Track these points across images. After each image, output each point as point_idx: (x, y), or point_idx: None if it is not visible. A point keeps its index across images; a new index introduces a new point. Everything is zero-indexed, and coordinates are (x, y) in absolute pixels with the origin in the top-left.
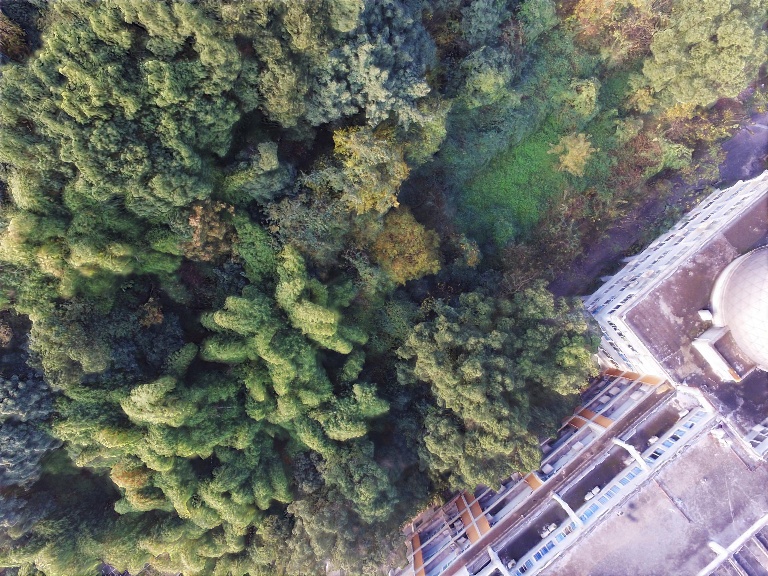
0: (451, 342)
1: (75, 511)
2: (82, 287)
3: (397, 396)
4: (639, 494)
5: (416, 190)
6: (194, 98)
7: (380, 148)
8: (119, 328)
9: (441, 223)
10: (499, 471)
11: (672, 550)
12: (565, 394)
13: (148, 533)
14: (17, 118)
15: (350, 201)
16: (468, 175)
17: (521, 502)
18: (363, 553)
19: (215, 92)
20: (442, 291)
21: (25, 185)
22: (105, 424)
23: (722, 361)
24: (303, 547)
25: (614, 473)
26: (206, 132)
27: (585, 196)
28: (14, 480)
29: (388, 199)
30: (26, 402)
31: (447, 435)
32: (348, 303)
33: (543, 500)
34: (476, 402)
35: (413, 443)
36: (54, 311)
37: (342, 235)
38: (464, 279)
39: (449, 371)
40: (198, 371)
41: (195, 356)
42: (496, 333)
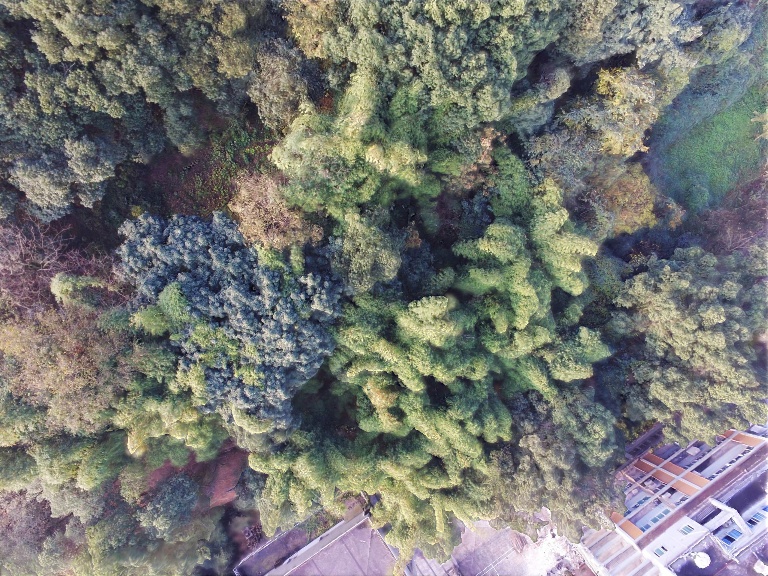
0: (681, 291)
1: (317, 427)
2: (381, 196)
3: None
4: None
5: None
6: (528, 14)
7: (648, 88)
8: (400, 243)
9: None
10: None
11: None
12: None
13: (385, 455)
14: (378, 18)
15: (605, 141)
16: (673, 137)
17: (743, 457)
18: (584, 495)
19: (547, 10)
20: (646, 248)
21: (376, 83)
22: (380, 335)
23: None
24: (536, 481)
25: None
26: (524, 51)
27: None
28: (297, 381)
29: (637, 143)
30: (329, 301)
31: (676, 382)
32: None
33: (767, 456)
34: (713, 349)
35: (617, 395)
36: (363, 215)
37: (583, 177)
38: (658, 241)
39: (686, 317)
40: None
41: (454, 280)
42: (731, 283)
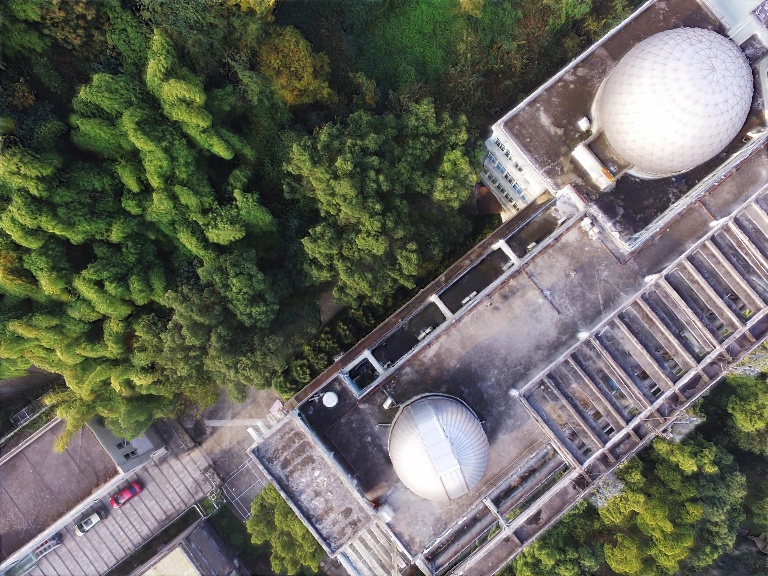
0: (331, 147)
1: None
2: None
3: (289, 221)
4: (509, 286)
5: (317, 30)
6: None
7: None
8: None
9: (339, 58)
10: (381, 282)
11: (541, 341)
12: (443, 198)
13: (20, 318)
14: None
15: None
16: (368, 14)
17: None
18: (240, 353)
19: None
20: None
21: None
22: None
23: (596, 161)
24: (174, 336)
25: (493, 279)
26: None
27: (491, 48)
28: None
29: None
30: None
31: None
32: (228, 106)
33: (421, 305)
34: (350, 198)
35: None
36: None
37: (222, 37)
38: None
39: None
40: (72, 158)
41: (64, 134)
42: (373, 135)
